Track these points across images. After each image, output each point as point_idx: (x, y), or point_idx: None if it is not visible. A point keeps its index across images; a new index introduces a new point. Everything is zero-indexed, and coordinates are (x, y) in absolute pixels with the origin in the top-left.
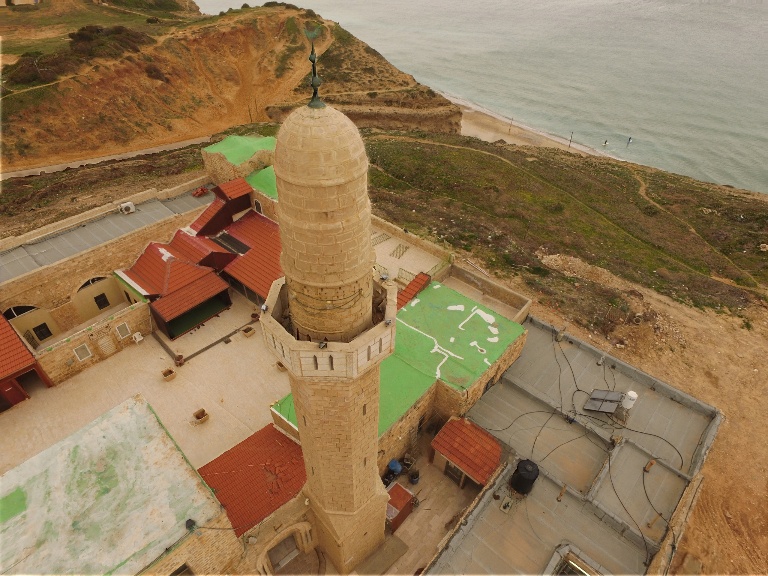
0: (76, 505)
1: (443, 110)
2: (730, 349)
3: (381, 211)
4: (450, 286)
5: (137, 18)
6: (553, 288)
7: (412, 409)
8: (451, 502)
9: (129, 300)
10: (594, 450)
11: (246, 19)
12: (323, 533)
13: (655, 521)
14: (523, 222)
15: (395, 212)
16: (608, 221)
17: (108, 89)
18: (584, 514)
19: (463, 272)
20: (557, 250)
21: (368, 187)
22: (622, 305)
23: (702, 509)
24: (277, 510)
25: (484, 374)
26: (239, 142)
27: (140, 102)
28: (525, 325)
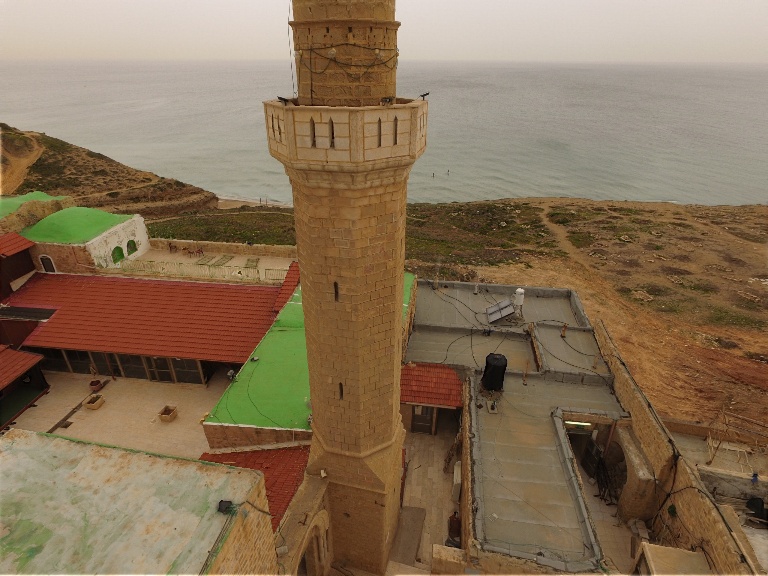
0: None
1: (198, 197)
2: (531, 282)
3: None
4: None
5: None
6: None
7: None
8: (434, 450)
9: None
10: (518, 345)
11: None
12: (347, 518)
13: (595, 363)
14: None
15: None
16: None
17: None
18: (549, 384)
19: None
20: None
21: None
22: (451, 271)
23: None
24: (290, 504)
25: (407, 313)
26: None
27: None
28: None
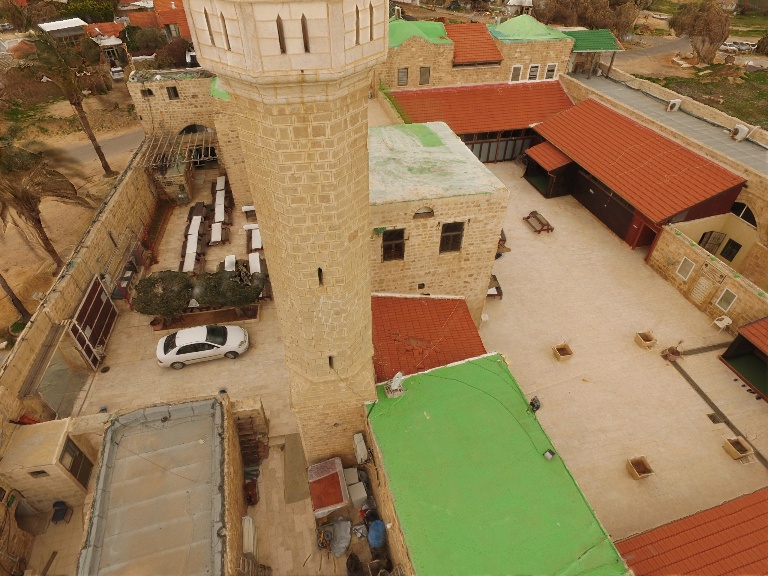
0: (409, 160)
1: None
2: None
3: None
4: None
5: None
6: None
7: None
8: None
9: None
10: None
11: None
12: None
13: None
14: None
15: None
16: None
17: None
18: None
19: None
20: None
21: None
22: None
23: None
24: None
25: None
26: None
27: None
28: None
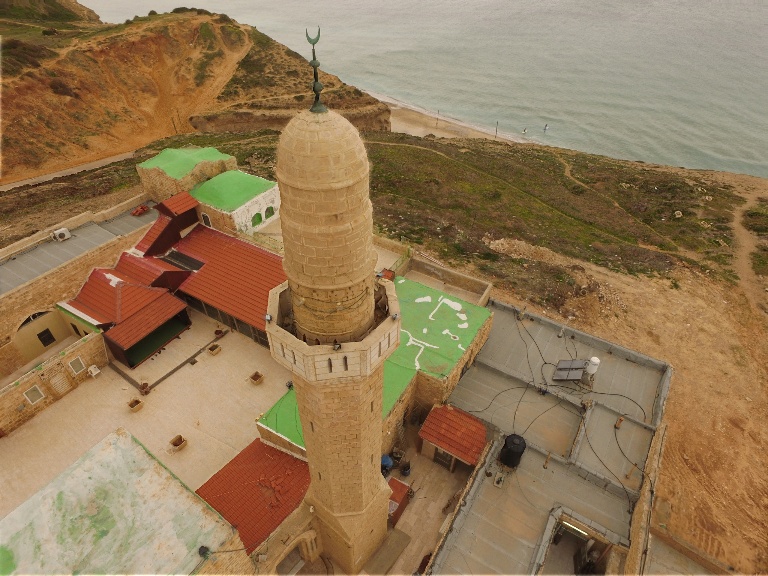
0: (73, 554)
1: (371, 109)
2: (664, 309)
3: None
4: None
5: (31, 30)
6: (504, 271)
7: (398, 403)
8: (444, 487)
9: (77, 333)
10: (568, 416)
11: (156, 27)
12: (329, 538)
13: (632, 472)
14: (466, 211)
15: None
16: (542, 203)
17: (9, 109)
18: (569, 476)
19: (423, 265)
20: (502, 235)
21: None
22: (568, 280)
23: None
24: (282, 523)
25: (460, 359)
26: (177, 155)
27: (48, 121)
28: None
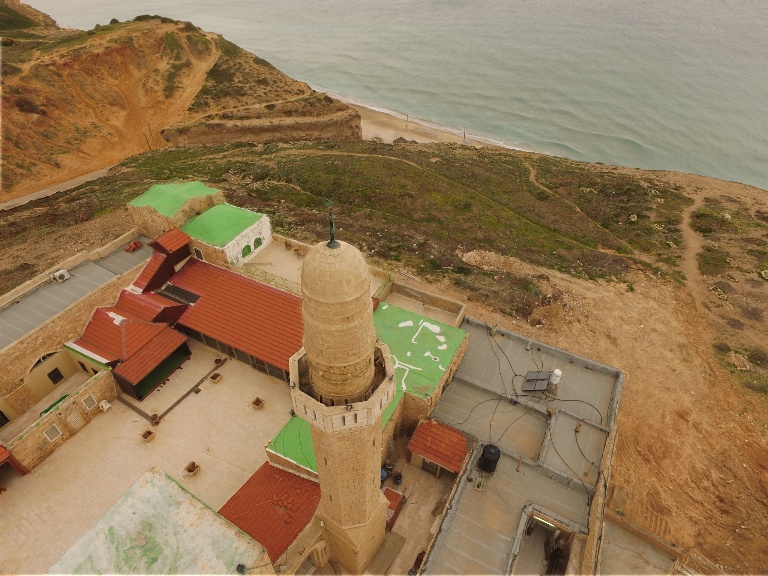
0: None
1: (342, 115)
2: (621, 312)
3: (311, 234)
4: (394, 302)
5: None
6: (477, 284)
7: (389, 422)
8: (432, 492)
9: (84, 369)
10: (536, 423)
11: (120, 37)
12: (337, 546)
13: (590, 470)
14: (439, 224)
15: (324, 233)
16: (510, 211)
17: None
18: (538, 477)
19: (403, 288)
20: (473, 247)
21: (291, 209)
22: (535, 290)
23: (620, 449)
24: (297, 537)
25: (441, 379)
26: (165, 191)
27: (17, 141)
28: (463, 326)
